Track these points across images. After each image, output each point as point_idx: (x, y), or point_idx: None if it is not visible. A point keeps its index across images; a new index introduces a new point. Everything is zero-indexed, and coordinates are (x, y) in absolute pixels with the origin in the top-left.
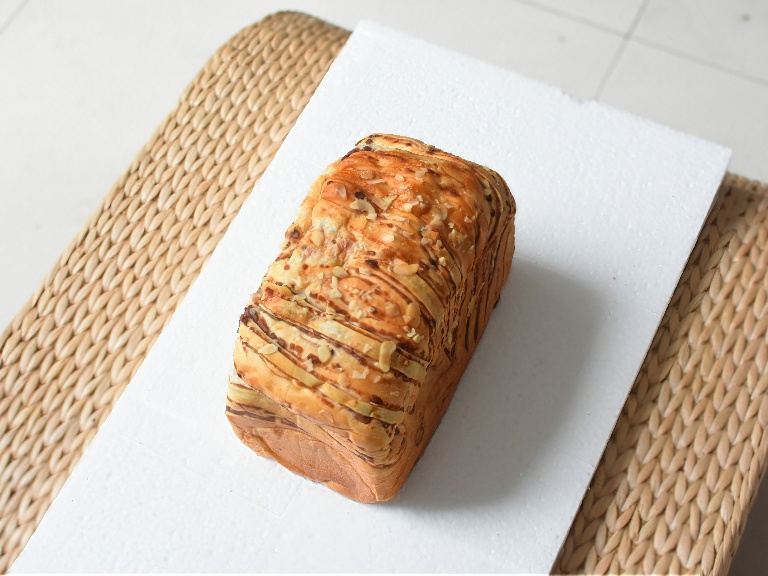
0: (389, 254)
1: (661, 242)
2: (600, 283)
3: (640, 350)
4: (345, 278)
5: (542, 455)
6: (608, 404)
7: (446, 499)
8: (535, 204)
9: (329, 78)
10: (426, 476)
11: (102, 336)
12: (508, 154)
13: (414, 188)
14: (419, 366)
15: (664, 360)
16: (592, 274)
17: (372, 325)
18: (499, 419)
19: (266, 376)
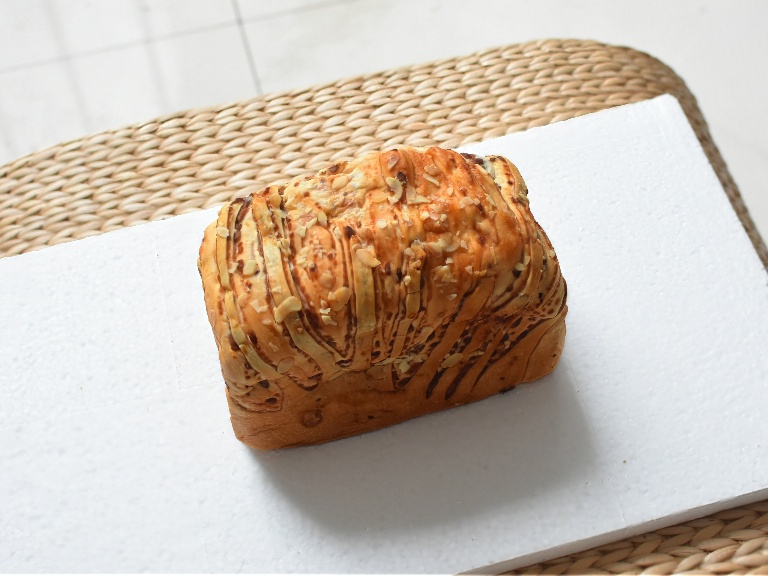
0: (369, 236)
1: (701, 471)
2: (609, 454)
3: (575, 534)
4: (322, 227)
5: (400, 532)
6: (497, 547)
7: (296, 491)
8: (633, 348)
9: (590, 118)
10: (303, 461)
11: (233, 169)
12: (660, 292)
13: (448, 206)
14: (322, 348)
15: (600, 568)
16: (611, 441)
17: (301, 277)
18: (403, 475)
19: (208, 252)
